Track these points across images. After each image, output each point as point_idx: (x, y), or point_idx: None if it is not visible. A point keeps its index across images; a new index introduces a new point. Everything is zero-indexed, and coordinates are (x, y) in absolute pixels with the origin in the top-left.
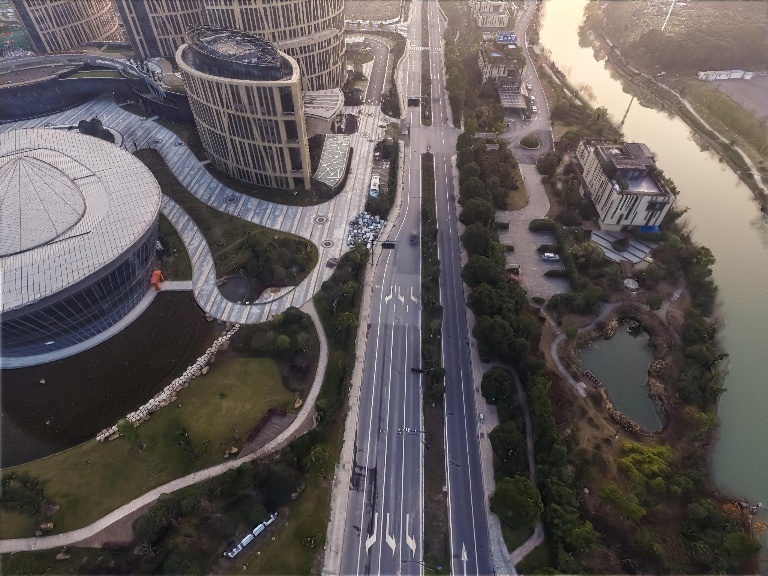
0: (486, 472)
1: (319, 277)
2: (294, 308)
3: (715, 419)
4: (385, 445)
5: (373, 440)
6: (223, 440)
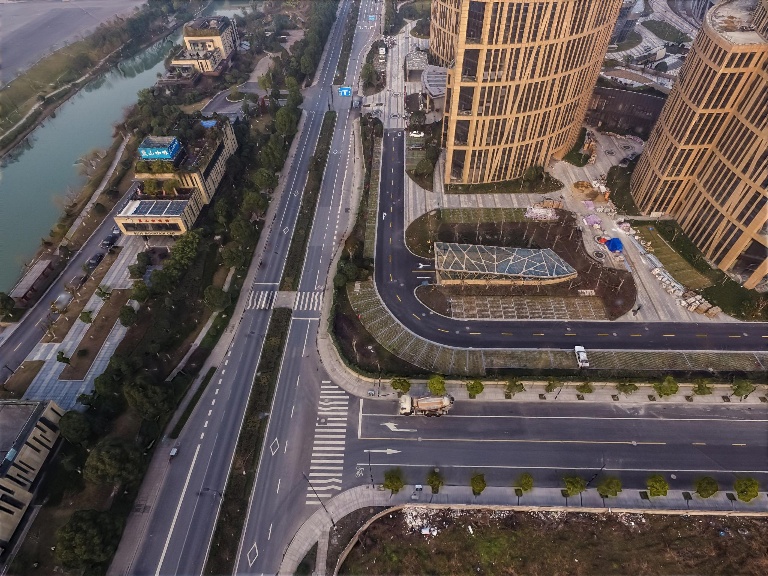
0: None
1: (407, 28)
2: (413, 9)
3: (261, 7)
4: None
5: (377, 5)
6: (425, 0)
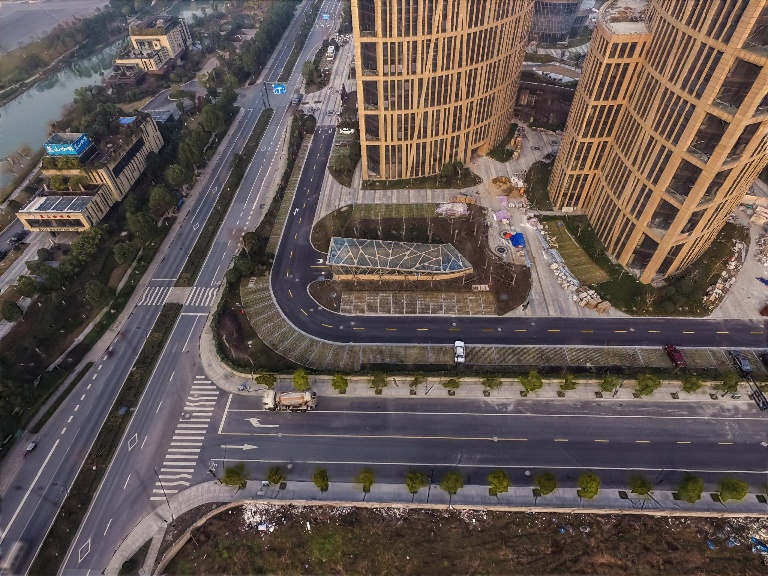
0: (304, 2)
1: None
2: None
3: (222, 7)
4: (334, 4)
5: None
6: None
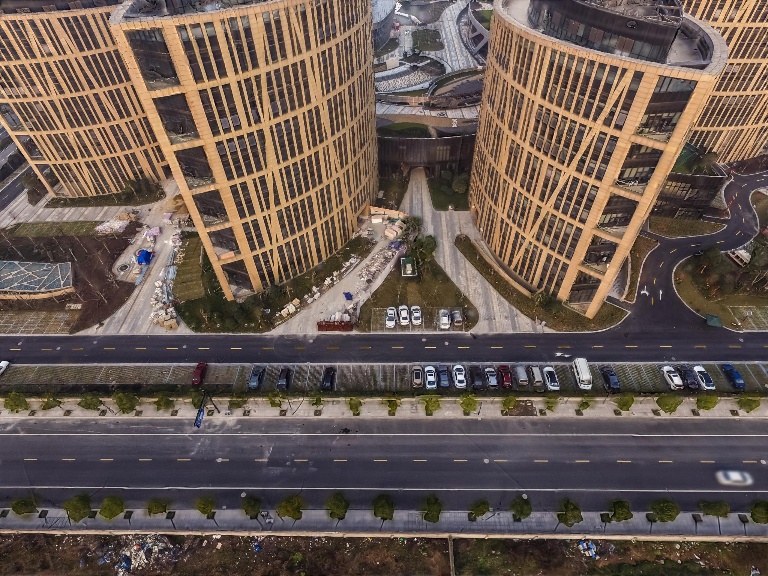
0: None
1: None
2: None
3: None
4: None
5: None
6: None
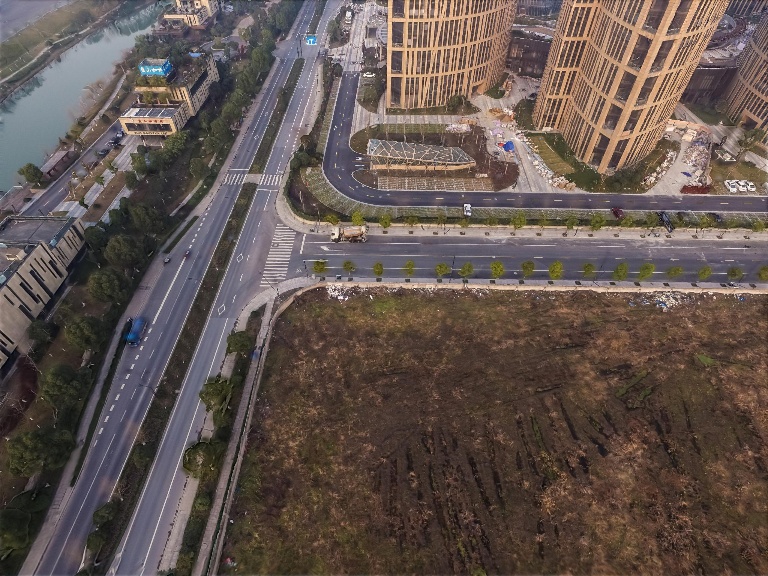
0: None
1: None
2: None
3: None
4: None
5: None
6: None
